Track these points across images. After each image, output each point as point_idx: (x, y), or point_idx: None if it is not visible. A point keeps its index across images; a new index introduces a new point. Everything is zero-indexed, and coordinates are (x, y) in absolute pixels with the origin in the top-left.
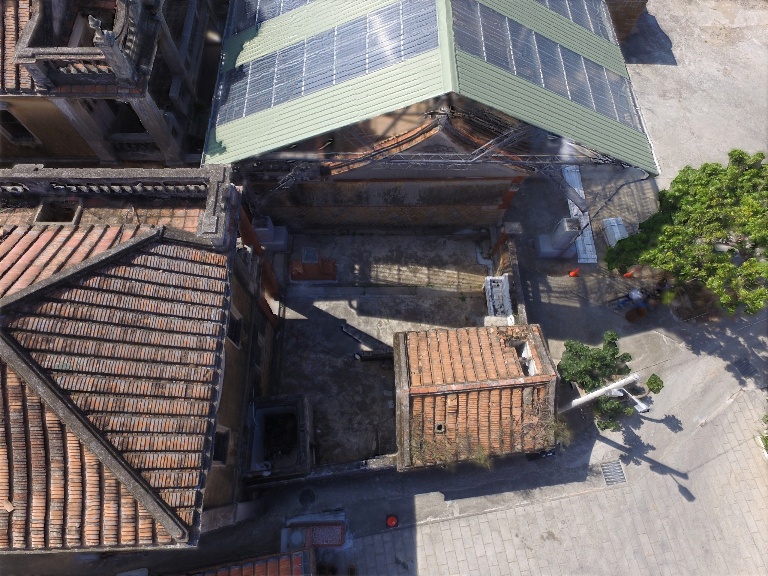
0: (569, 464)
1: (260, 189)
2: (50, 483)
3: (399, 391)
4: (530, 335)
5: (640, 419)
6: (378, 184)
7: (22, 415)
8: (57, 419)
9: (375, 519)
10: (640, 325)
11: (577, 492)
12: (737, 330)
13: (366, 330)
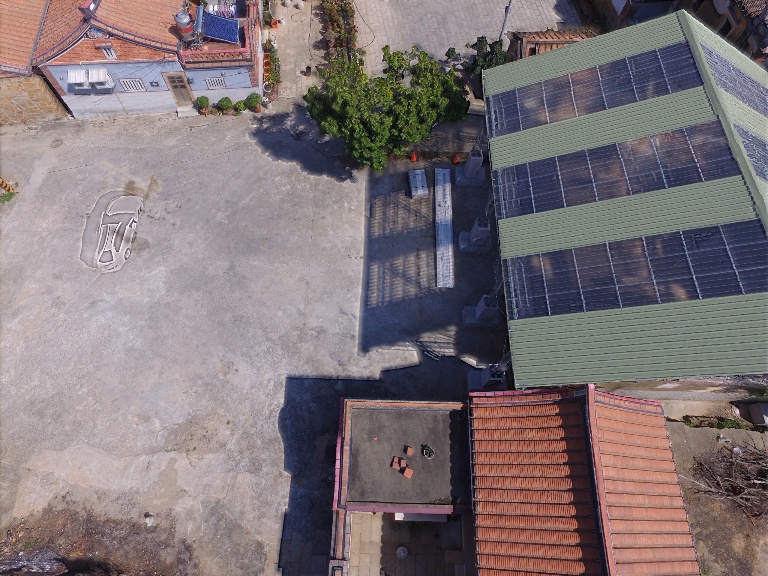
0: None
1: None
2: None
3: None
4: None
5: None
6: None
7: None
8: None
9: None
10: None
11: None
12: None
13: None
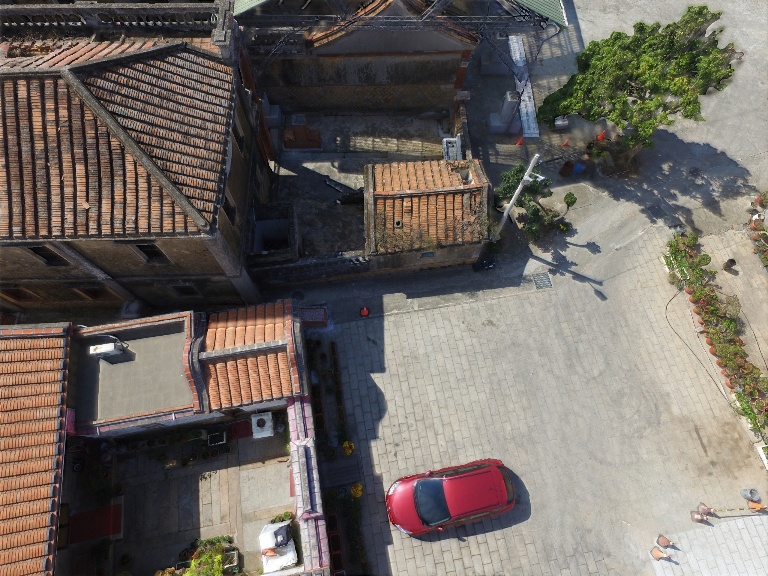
0: (507, 274)
1: (257, 64)
2: (114, 191)
3: (366, 194)
4: (472, 165)
5: (566, 244)
6: (353, 60)
7: (95, 141)
8: (119, 143)
9: (351, 311)
10: (571, 179)
11: (512, 294)
12: (653, 185)
13: (345, 183)
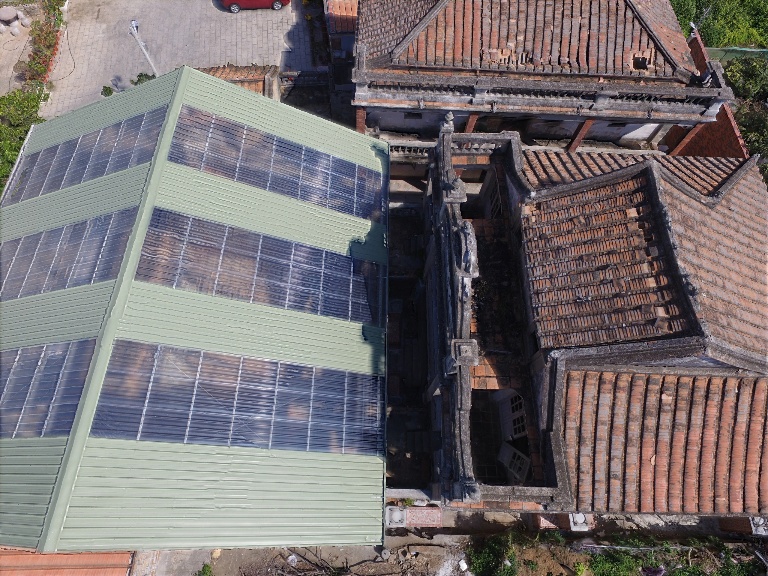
0: None
1: None
2: None
3: (271, 79)
4: None
5: None
6: None
7: None
8: None
9: None
10: None
11: None
12: None
13: None
